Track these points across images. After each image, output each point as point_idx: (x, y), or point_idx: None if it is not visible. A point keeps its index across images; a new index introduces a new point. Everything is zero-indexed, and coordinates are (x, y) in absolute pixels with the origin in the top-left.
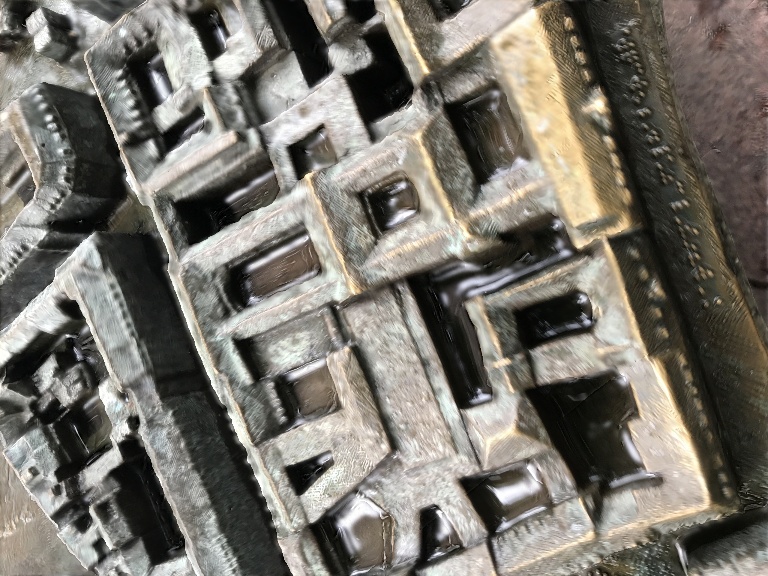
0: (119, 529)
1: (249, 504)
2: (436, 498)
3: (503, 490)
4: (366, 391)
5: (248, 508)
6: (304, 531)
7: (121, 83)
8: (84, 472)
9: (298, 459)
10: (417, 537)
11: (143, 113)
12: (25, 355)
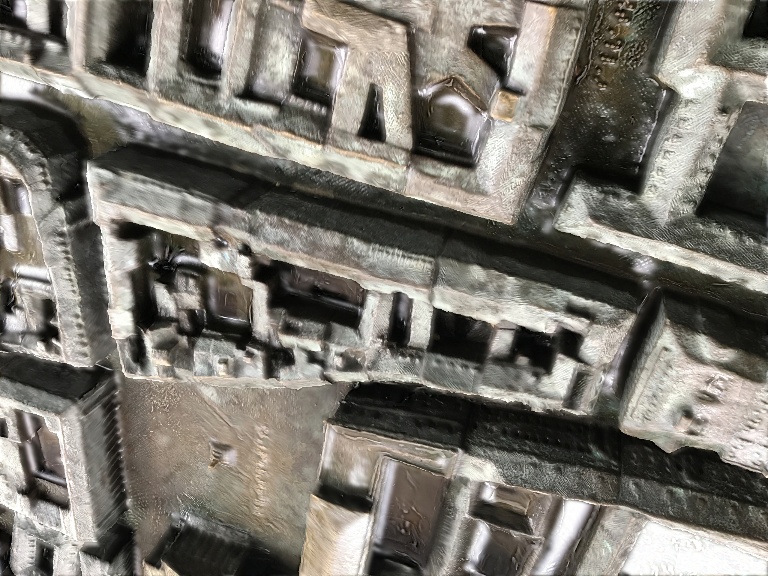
0: (311, 329)
1: (374, 222)
2: (468, 22)
3: None
4: (349, 10)
5: (375, 224)
6: (412, 160)
7: None
8: (254, 330)
9: (359, 118)
10: (484, 67)
11: (23, 34)
12: (140, 306)
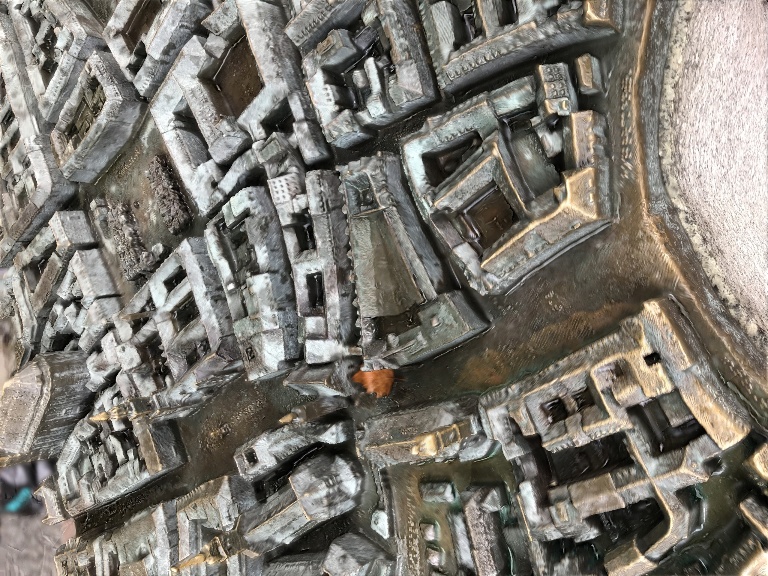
0: None
1: None
2: None
3: None
4: None
5: None
6: None
7: None
8: None
9: None
10: None
11: None
12: None
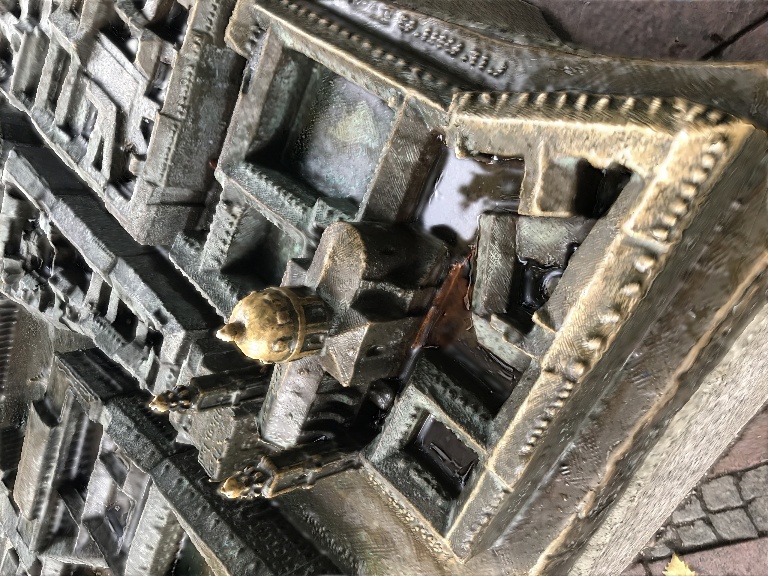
0: (63, 284)
1: None
2: (141, 114)
3: (163, 84)
4: (101, 92)
5: None
6: (108, 186)
7: None
8: None
9: (94, 154)
10: (144, 142)
11: (7, 68)
12: (14, 244)
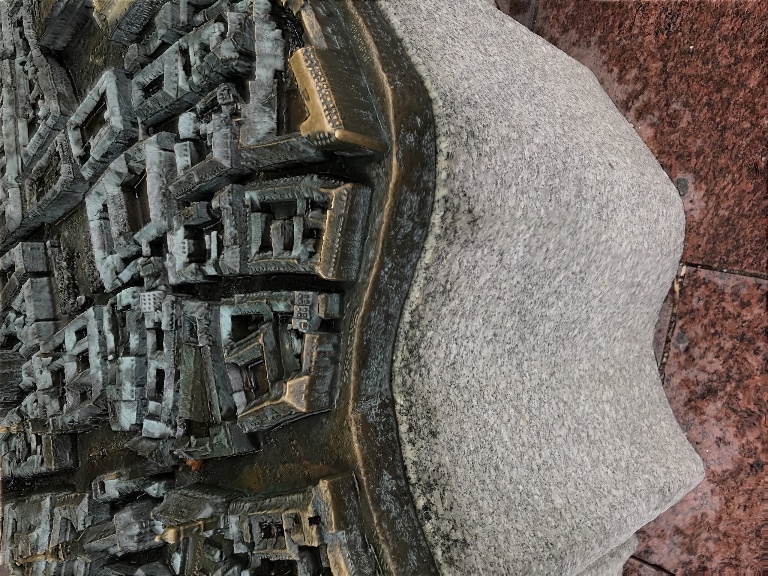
0: None
1: None
2: None
3: None
4: None
5: None
6: None
7: None
8: None
9: None
10: None
11: None
12: None
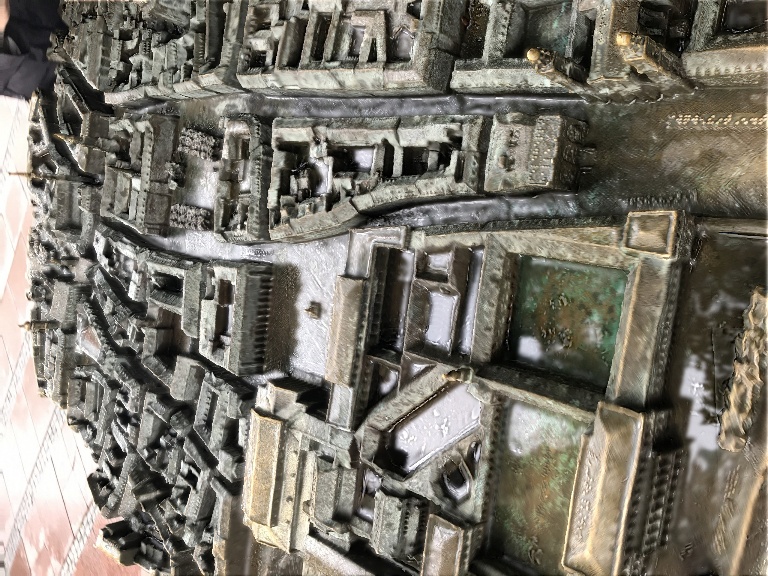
0: (348, 174)
1: None
2: (406, 2)
3: None
4: (366, 12)
5: None
6: (386, 66)
7: (251, 69)
8: None
9: (368, 55)
10: (413, 18)
11: None
12: (283, 192)
